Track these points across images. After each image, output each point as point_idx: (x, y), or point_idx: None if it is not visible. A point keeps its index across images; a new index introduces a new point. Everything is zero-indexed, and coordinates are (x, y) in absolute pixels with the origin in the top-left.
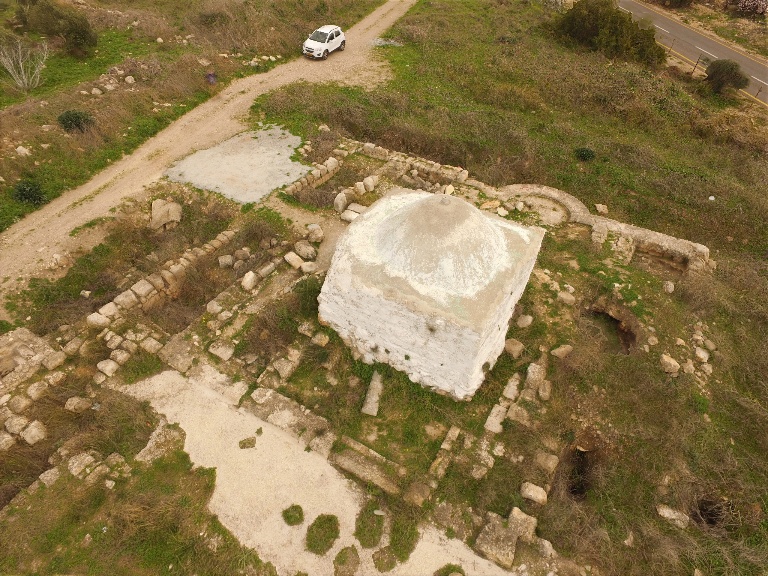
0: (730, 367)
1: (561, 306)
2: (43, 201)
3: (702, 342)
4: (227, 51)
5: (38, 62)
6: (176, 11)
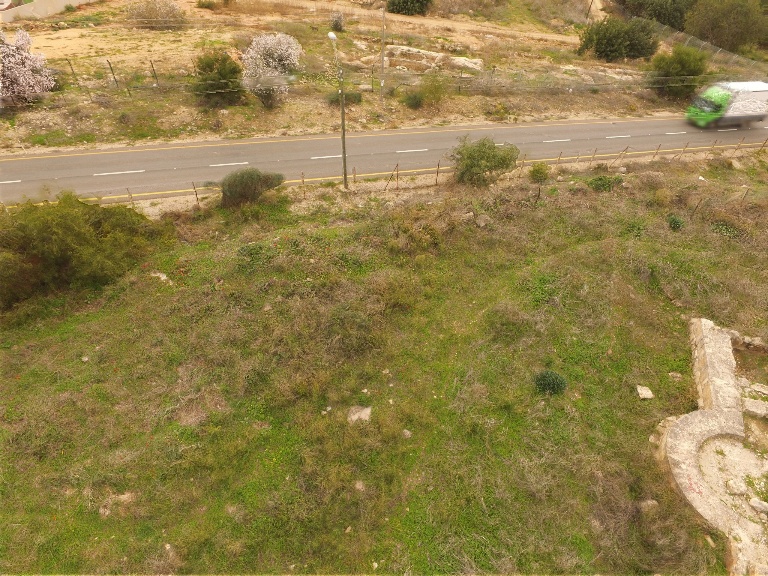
0: None
1: None
2: None
3: None
4: None
5: None
6: None
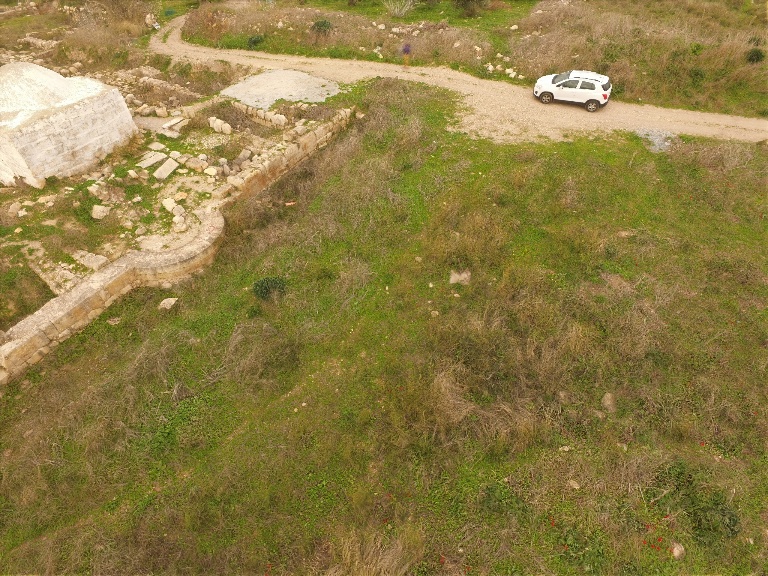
0: None
1: None
2: (251, 48)
3: None
4: None
5: (407, 1)
6: None
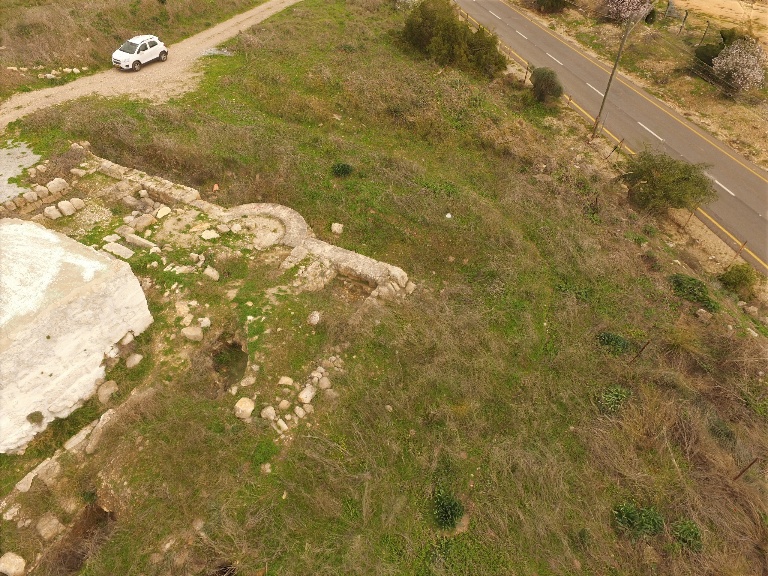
0: (339, 407)
1: (184, 342)
2: None
3: (317, 380)
4: (31, 63)
5: None
6: (6, 21)
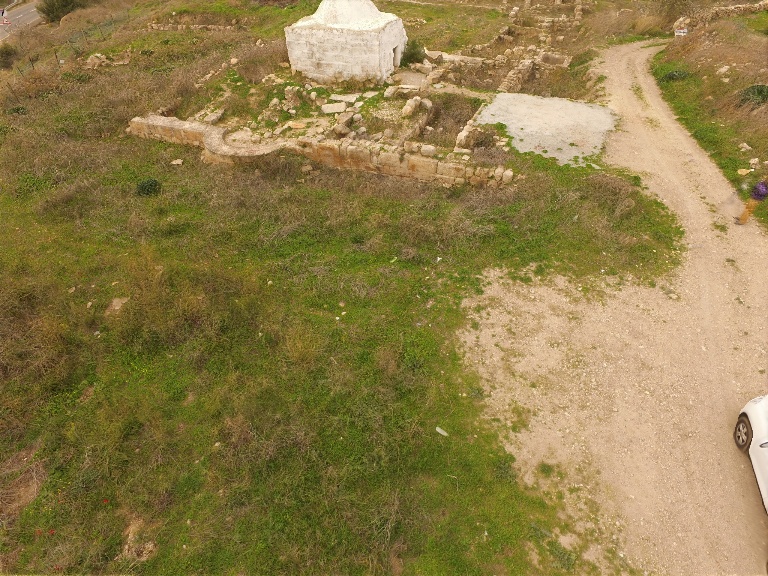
0: None
1: None
2: None
3: None
4: None
5: None
6: None
